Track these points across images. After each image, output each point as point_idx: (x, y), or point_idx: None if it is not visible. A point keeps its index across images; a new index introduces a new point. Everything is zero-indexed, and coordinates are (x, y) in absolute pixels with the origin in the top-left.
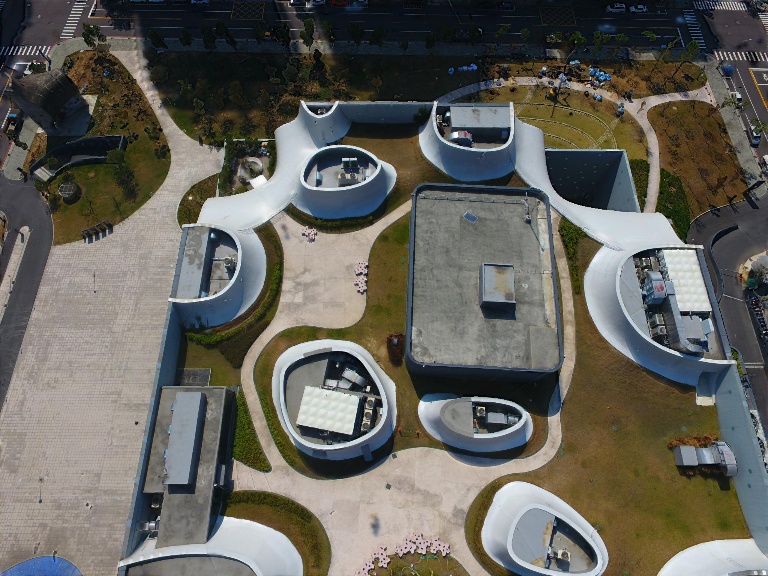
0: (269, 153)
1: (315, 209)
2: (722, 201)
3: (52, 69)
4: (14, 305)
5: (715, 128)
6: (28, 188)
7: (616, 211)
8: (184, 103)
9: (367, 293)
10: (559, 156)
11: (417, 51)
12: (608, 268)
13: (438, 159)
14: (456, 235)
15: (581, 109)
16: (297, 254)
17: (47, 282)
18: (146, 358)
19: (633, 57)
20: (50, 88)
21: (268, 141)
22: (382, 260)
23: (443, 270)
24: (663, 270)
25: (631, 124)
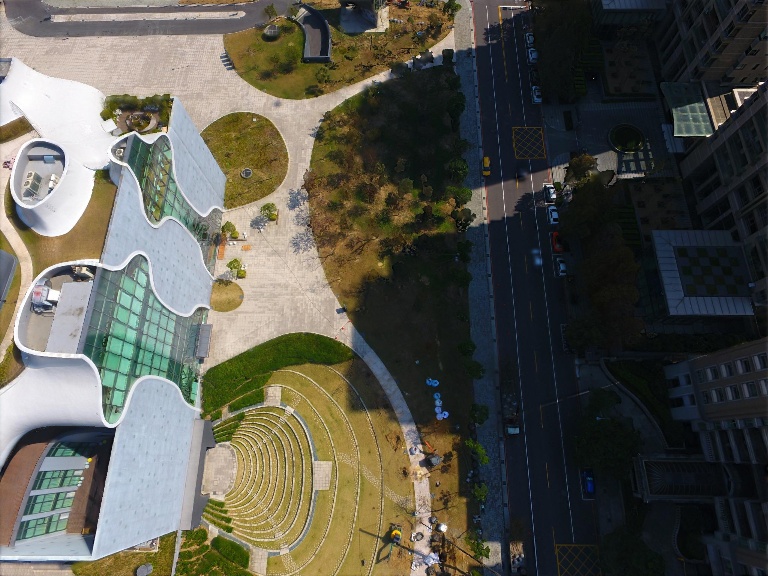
0: None
1: None
2: None
3: None
4: (175, 24)
5: None
6: (286, 8)
7: None
8: None
9: None
10: None
11: (478, 341)
12: None
13: None
14: None
15: None
16: None
17: (190, 38)
18: None
19: None
20: None
21: None
22: None
23: None
24: None
25: None
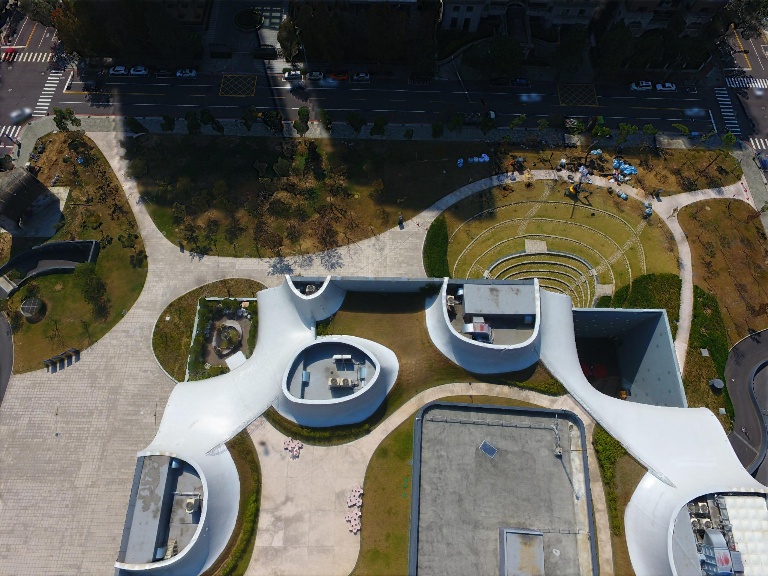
0: (250, 315)
1: (300, 416)
2: (763, 324)
3: (21, 154)
4: None
5: (753, 233)
6: None
7: (659, 410)
8: (165, 198)
9: (361, 532)
10: (588, 314)
11: (423, 136)
12: (656, 512)
13: (448, 349)
14: (471, 475)
15: (604, 209)
16: (278, 476)
17: (3, 421)
18: (111, 522)
19: (661, 145)
20: (13, 191)
21: (249, 304)
22: (380, 484)
23: (455, 528)
24: (725, 524)
25: (660, 228)
